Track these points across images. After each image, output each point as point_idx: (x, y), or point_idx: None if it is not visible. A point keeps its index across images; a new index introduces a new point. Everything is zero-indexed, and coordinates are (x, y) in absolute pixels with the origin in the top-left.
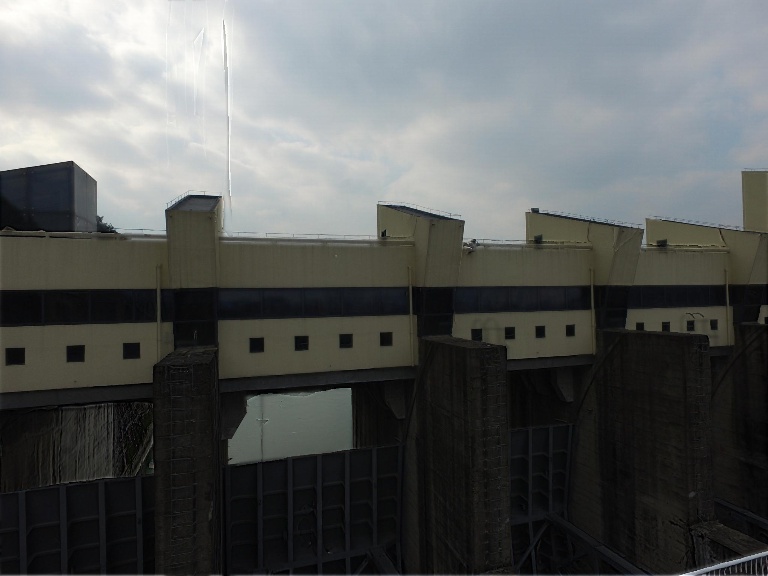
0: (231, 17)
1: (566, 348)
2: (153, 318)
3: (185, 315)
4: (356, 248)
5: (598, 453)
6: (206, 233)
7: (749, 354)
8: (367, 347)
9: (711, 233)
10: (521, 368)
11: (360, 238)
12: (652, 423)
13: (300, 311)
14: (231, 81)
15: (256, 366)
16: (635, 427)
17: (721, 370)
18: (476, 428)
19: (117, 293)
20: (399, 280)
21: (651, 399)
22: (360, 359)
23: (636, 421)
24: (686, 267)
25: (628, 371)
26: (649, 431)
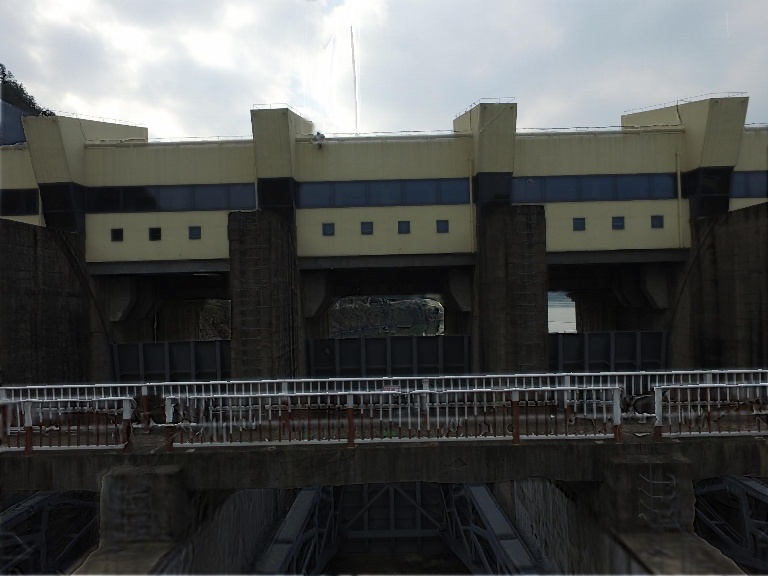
0: (358, 20)
1: (437, 245)
2: (38, 212)
3: (53, 206)
4: (204, 148)
5: (479, 361)
6: (55, 135)
7: (703, 255)
8: (215, 239)
9: (669, 113)
10: (383, 265)
11: (209, 139)
12: (495, 314)
13: (154, 206)
14: (359, 81)
15: (117, 253)
16: (489, 323)
17: (680, 281)
18: (234, 288)
19: (13, 192)
20: (247, 177)
21: (494, 287)
22: (209, 250)
23: (490, 316)
24: (612, 153)
25: (487, 262)
26: (494, 323)
